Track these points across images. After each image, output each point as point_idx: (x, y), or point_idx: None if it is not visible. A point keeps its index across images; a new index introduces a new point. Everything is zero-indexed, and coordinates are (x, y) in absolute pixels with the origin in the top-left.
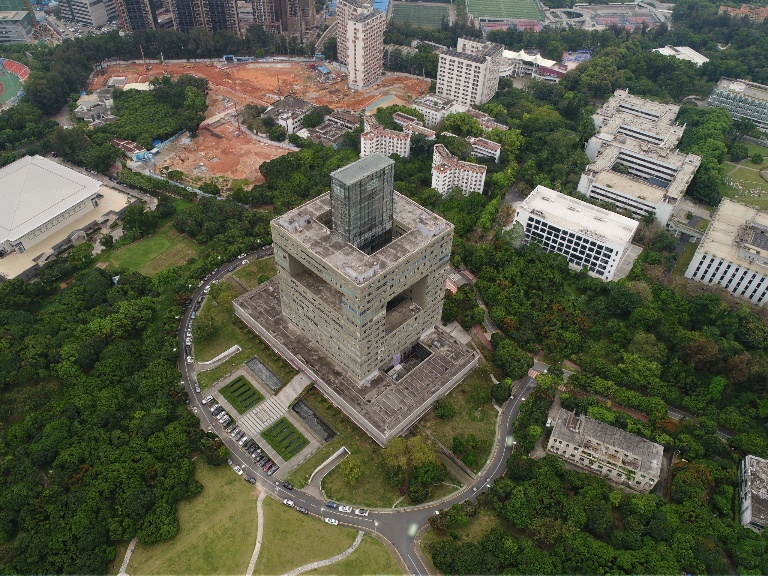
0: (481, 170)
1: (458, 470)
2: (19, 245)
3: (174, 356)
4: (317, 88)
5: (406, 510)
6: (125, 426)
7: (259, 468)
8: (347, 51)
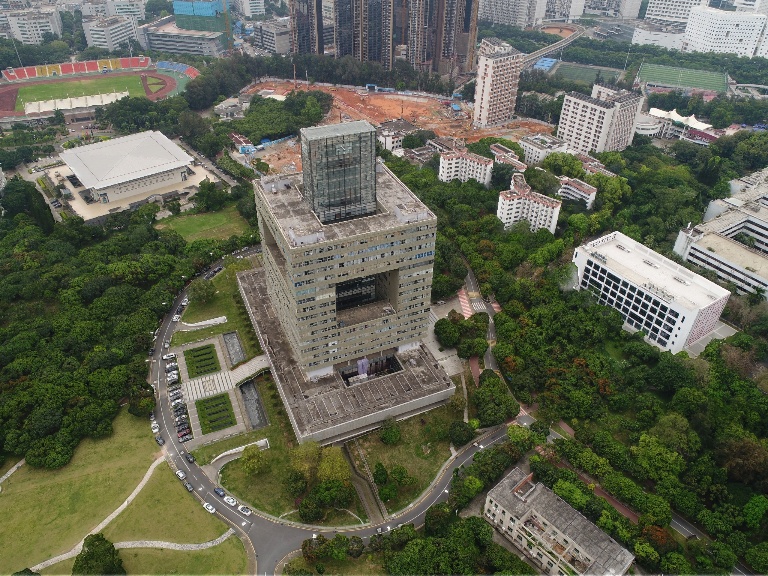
0: (552, 204)
1: (372, 503)
2: (104, 196)
3: (161, 309)
4: (441, 121)
5: (291, 525)
6: (84, 357)
7: (175, 432)
8: (476, 87)
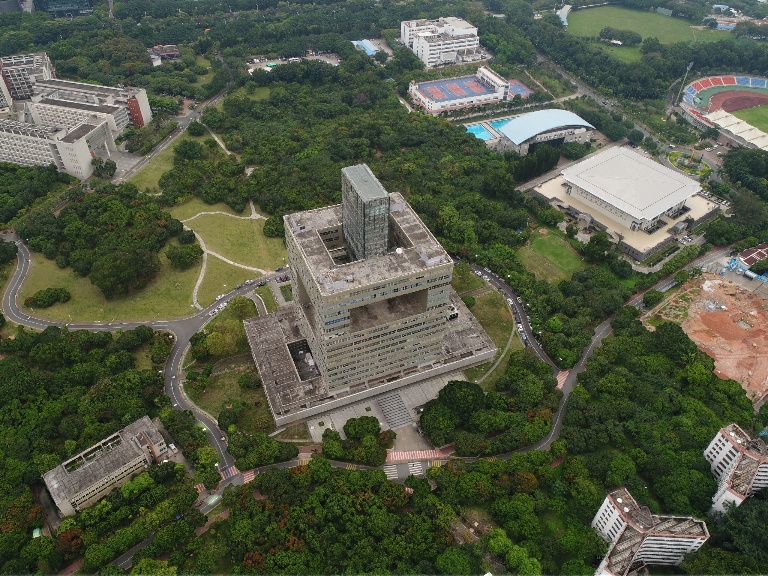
0: (609, 561)
1: None
2: (570, 188)
3: None
4: None
5: None
6: None
7: None
8: None
